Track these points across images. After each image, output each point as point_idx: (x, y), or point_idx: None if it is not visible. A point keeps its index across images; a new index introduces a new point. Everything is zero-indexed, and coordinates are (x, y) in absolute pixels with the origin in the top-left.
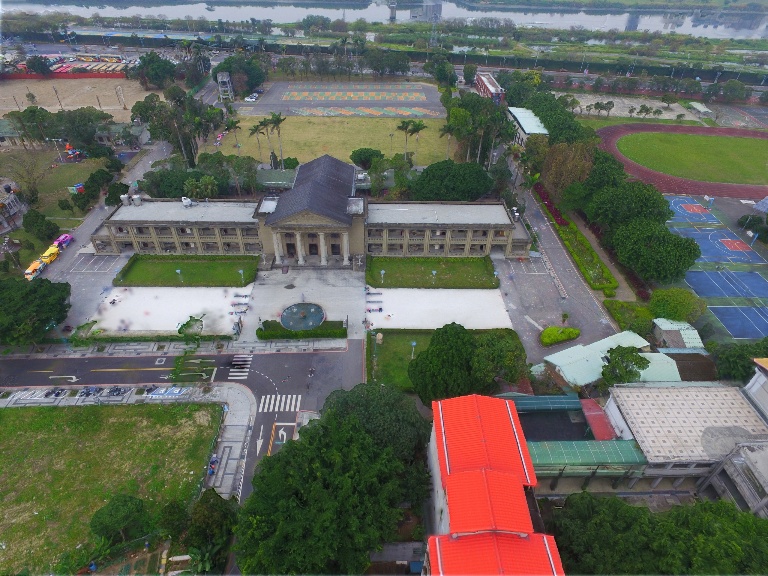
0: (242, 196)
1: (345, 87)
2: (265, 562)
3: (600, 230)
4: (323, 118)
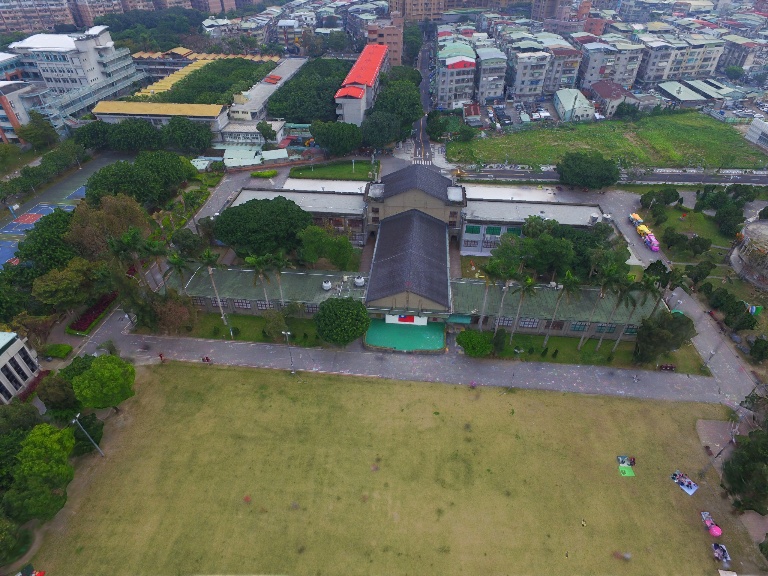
0: None
1: None
2: None
3: None
4: None
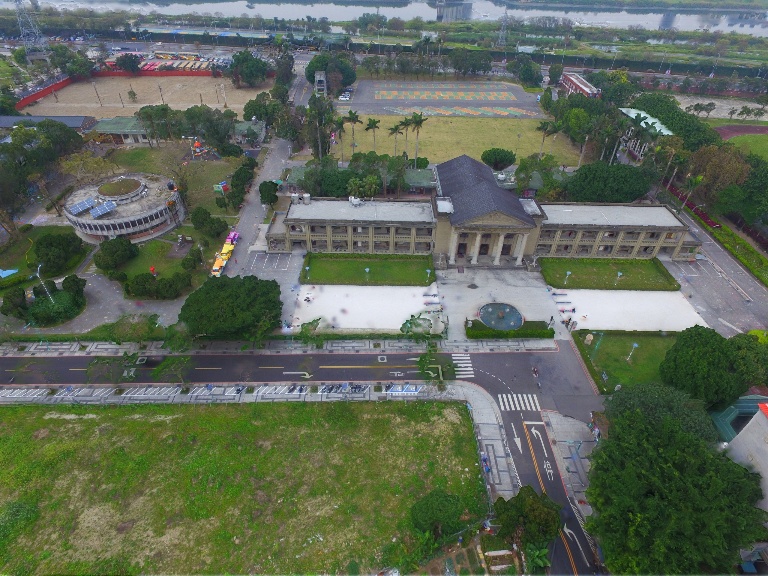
0: (383, 195)
1: (431, 86)
2: (662, 559)
3: (758, 233)
4: (424, 117)
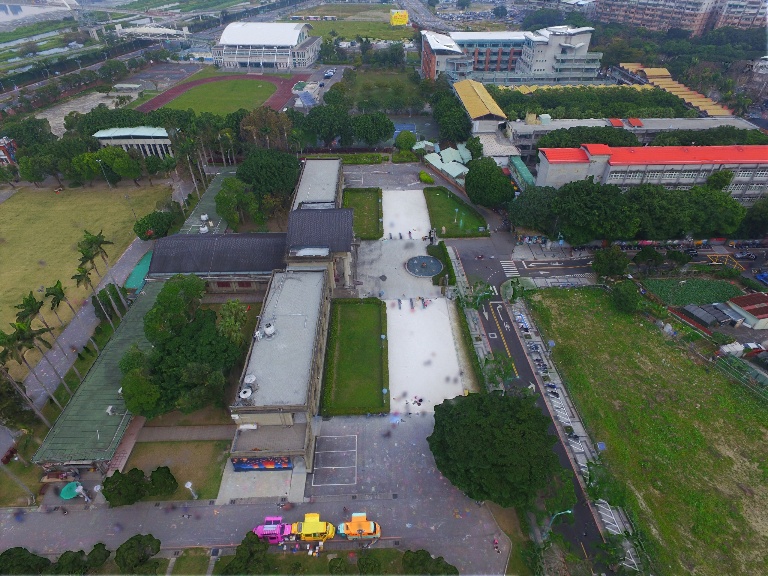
0: None
1: None
2: None
3: (321, 148)
4: None
